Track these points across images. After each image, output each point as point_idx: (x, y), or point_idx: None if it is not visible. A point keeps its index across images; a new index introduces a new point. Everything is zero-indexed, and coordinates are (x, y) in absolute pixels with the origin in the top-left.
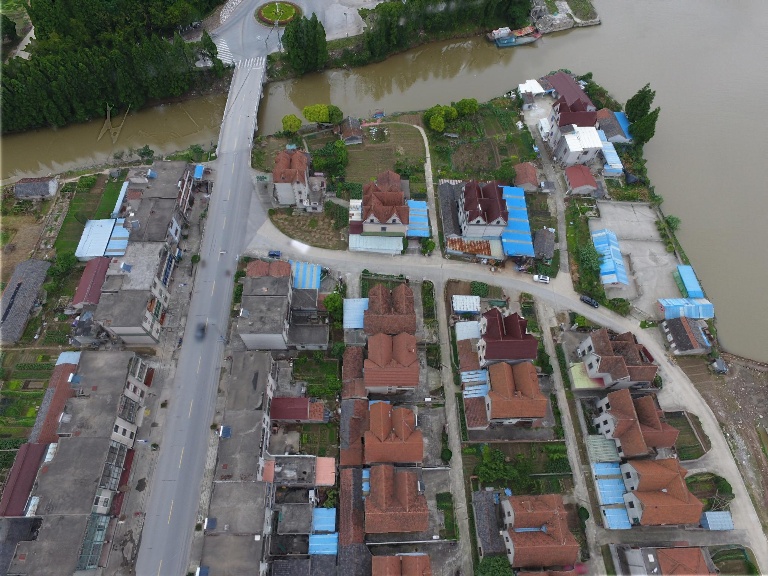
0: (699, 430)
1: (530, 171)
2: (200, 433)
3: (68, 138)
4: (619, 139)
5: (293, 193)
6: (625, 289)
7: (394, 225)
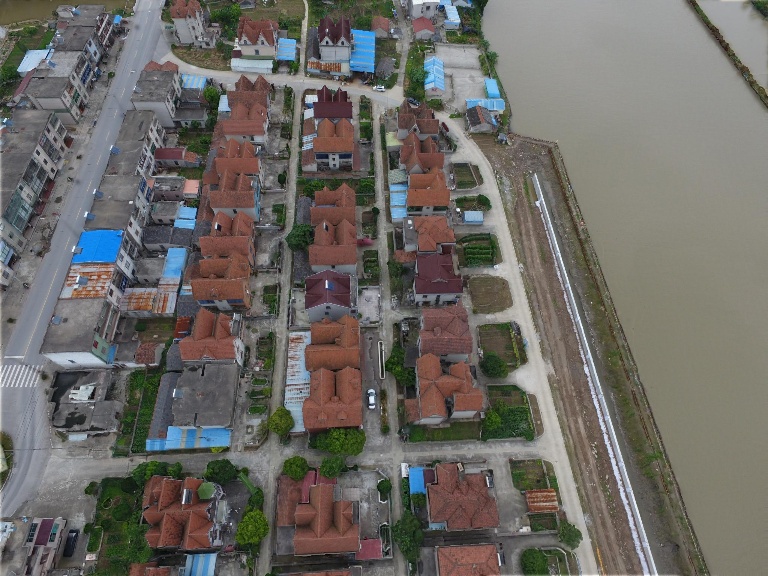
0: (477, 174)
1: (383, 22)
2: None
3: (18, 9)
4: (462, 4)
5: (189, 30)
6: (444, 96)
7: (263, 47)
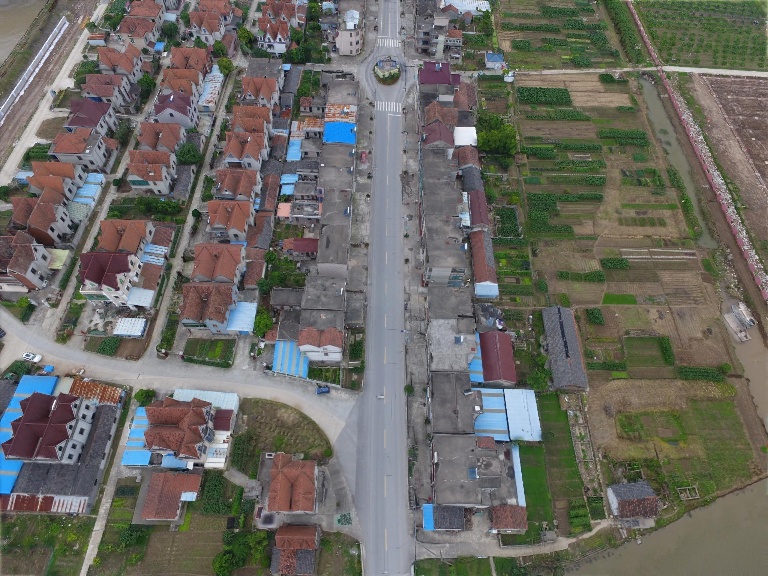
0: None
1: None
2: (376, 243)
3: None
4: None
5: None
6: None
7: None
